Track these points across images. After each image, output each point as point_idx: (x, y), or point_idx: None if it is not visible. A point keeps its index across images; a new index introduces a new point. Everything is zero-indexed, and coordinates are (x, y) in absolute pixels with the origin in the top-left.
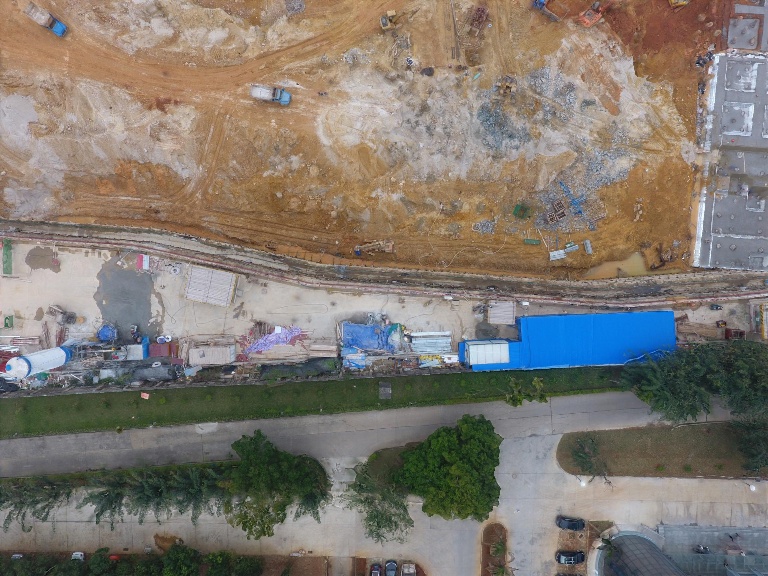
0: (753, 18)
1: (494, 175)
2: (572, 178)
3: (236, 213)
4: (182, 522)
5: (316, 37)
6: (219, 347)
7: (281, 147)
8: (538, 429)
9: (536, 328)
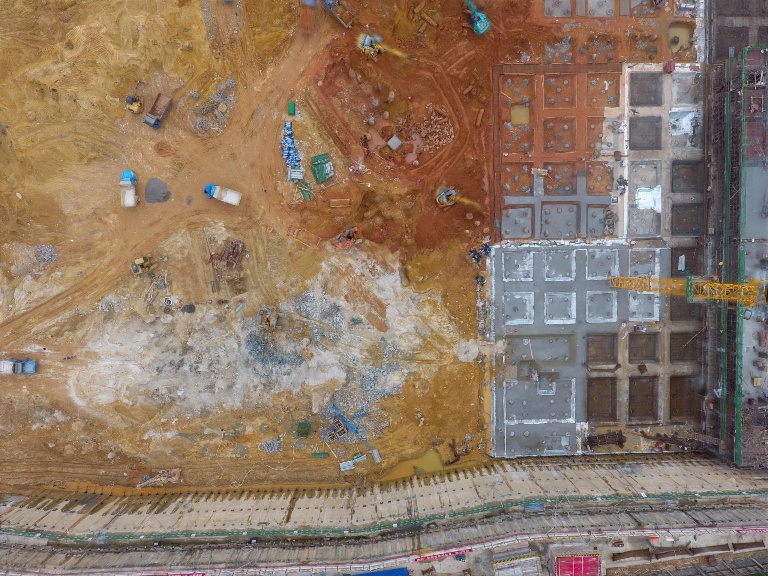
0: (525, 207)
1: (267, 403)
2: (350, 393)
3: (16, 460)
4: None
5: (67, 290)
6: None
7: (42, 404)
8: None
9: None
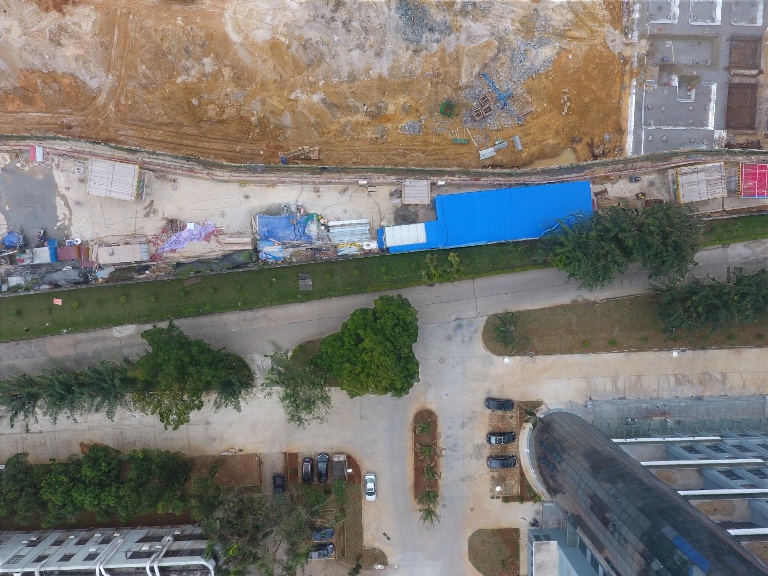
0: None
1: (416, 71)
2: (497, 72)
3: (154, 126)
4: (107, 428)
5: None
6: (129, 245)
7: (191, 49)
8: (463, 312)
9: (451, 206)
